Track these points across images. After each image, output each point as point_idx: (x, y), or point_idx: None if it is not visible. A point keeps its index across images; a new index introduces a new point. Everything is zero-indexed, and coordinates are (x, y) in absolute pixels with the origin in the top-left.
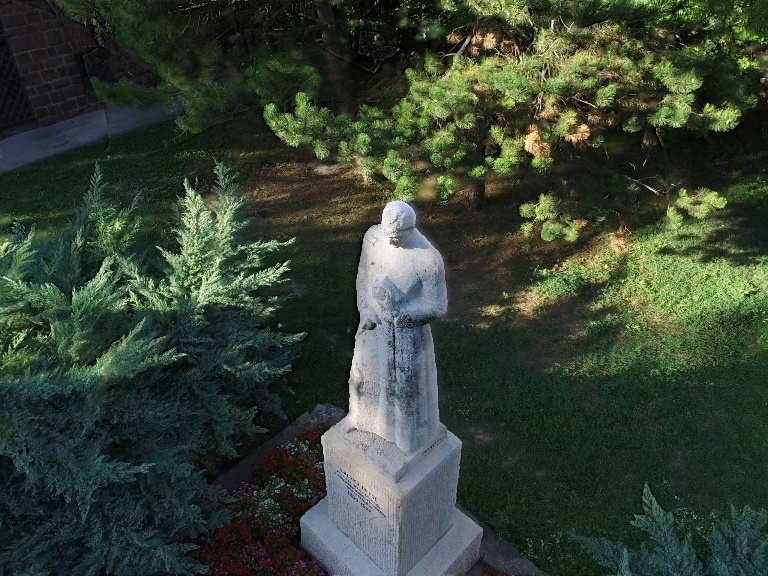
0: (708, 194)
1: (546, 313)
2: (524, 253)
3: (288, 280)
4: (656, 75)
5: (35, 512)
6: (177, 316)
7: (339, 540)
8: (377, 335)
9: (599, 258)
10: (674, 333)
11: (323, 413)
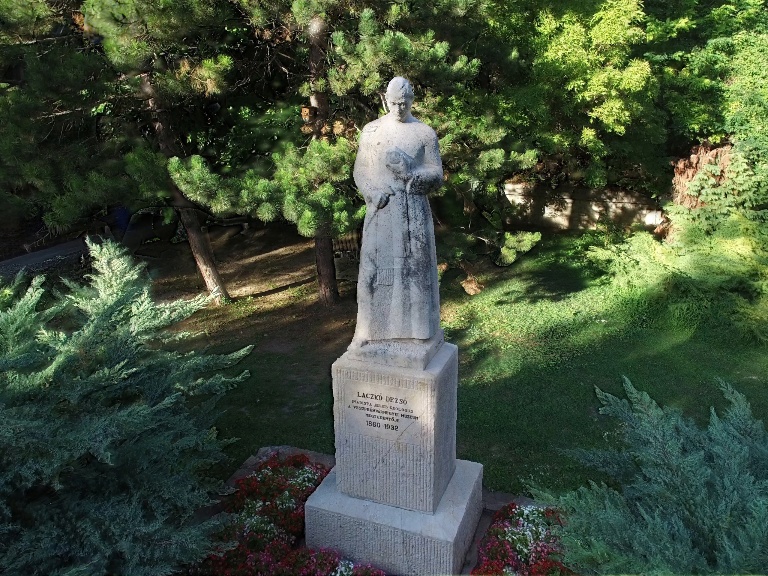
0: (525, 235)
1: None
2: None
3: (202, 333)
4: (473, 133)
5: (0, 530)
6: (105, 355)
7: (355, 505)
8: (390, 209)
9: None
10: (539, 344)
11: (269, 452)
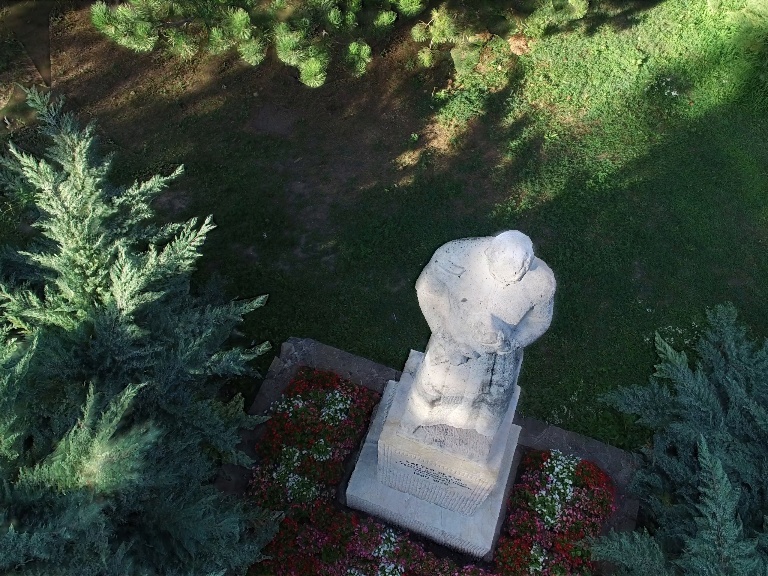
0: None
1: (462, 145)
2: (410, 73)
3: None
4: None
5: None
6: (95, 331)
7: (397, 499)
8: (470, 365)
9: (489, 58)
10: (590, 131)
11: (293, 352)
